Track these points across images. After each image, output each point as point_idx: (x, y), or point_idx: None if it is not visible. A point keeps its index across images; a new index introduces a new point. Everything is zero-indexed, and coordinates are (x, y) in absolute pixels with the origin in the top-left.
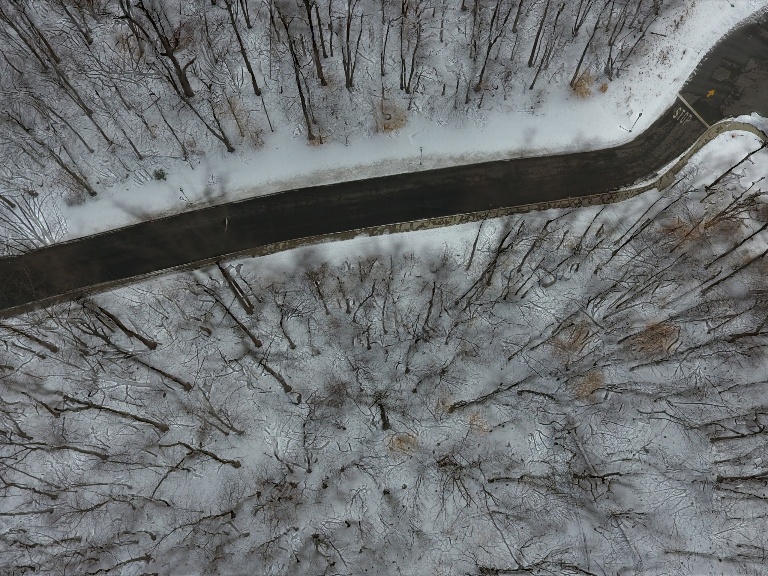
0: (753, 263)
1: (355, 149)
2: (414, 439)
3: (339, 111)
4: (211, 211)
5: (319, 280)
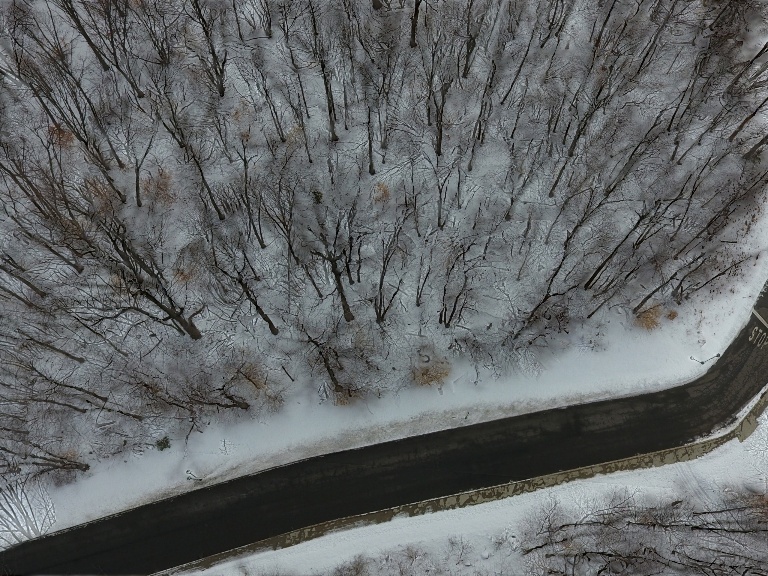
0: None
1: (389, 401)
2: None
3: (369, 353)
4: (223, 487)
5: None
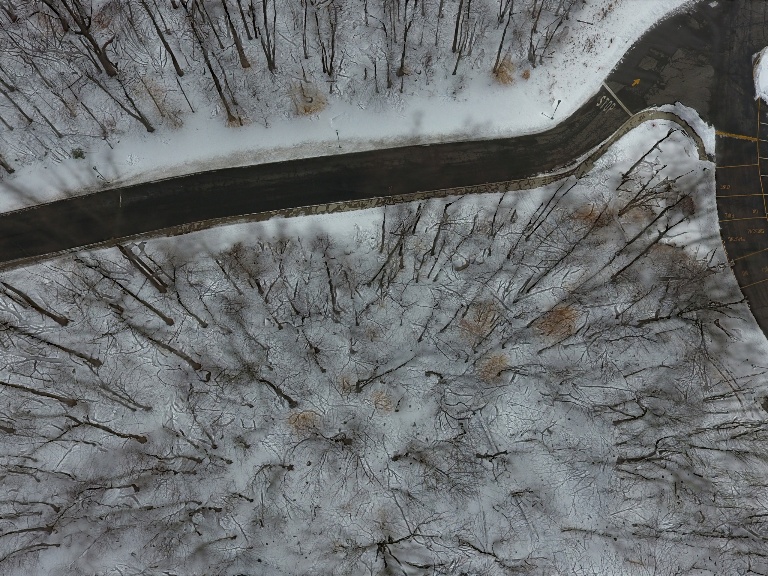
0: (665, 250)
1: (275, 131)
2: (321, 417)
3: (261, 93)
4: (128, 190)
5: (232, 260)
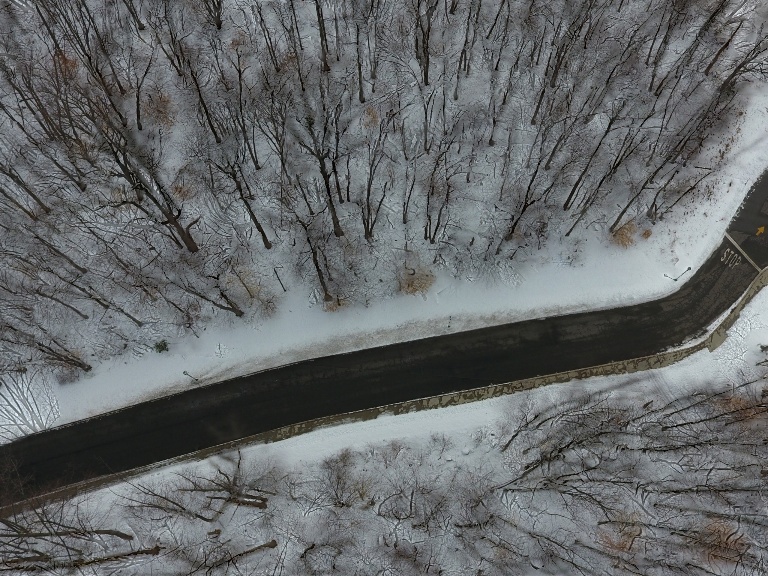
0: None
1: (376, 310)
2: None
3: (358, 266)
4: (218, 387)
5: (339, 469)
